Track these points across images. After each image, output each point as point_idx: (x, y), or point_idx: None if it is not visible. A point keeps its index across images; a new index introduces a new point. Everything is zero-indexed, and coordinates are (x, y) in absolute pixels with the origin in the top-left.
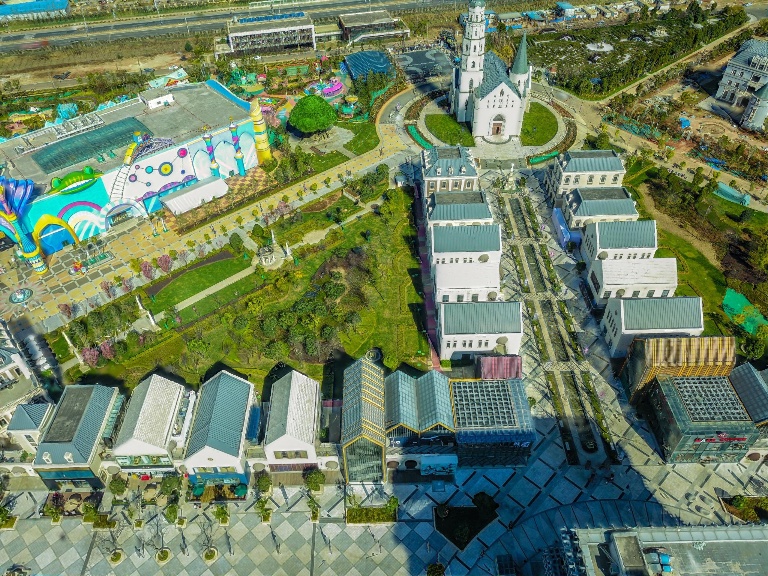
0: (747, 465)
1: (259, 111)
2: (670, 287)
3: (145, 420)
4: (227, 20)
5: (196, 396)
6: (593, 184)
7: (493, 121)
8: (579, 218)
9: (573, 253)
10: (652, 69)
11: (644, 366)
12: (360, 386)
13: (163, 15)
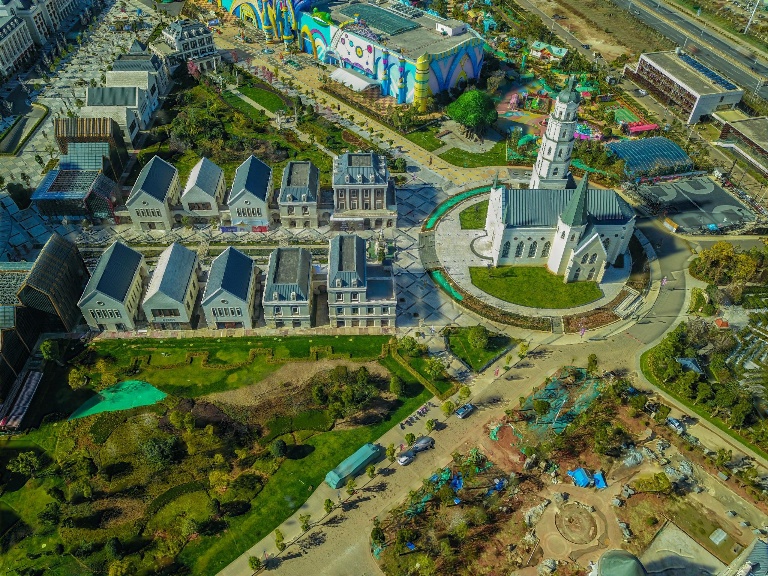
0: None
1: (421, 62)
2: None
3: (119, 74)
4: None
5: (165, 110)
6: None
7: None
8: None
9: None
10: None
11: None
12: None
13: (733, 37)
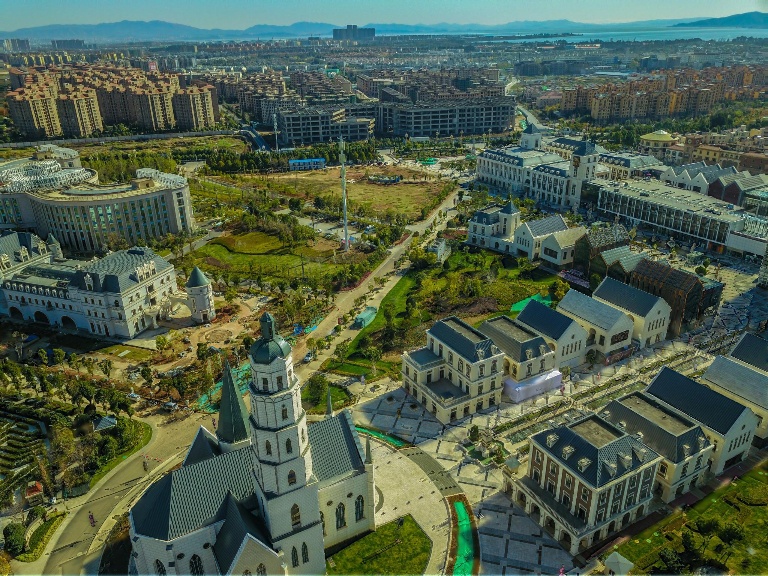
0: None
1: None
2: None
3: None
4: None
5: None
6: None
7: None
8: None
9: None
10: None
11: (701, 292)
12: None
13: None
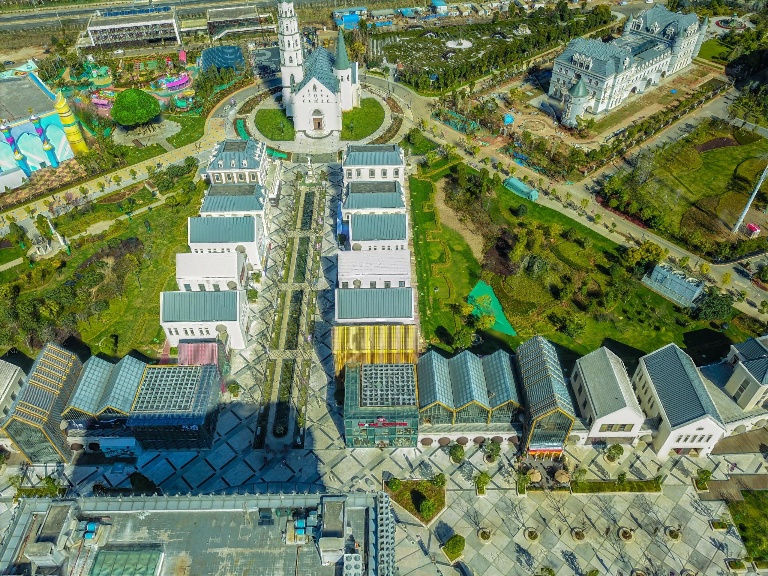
0: (423, 450)
1: (63, 103)
2: (404, 278)
3: None
4: (92, 14)
5: None
6: (376, 178)
7: (312, 116)
8: (347, 211)
9: (344, 245)
10: (500, 66)
11: None
12: (33, 370)
13: (46, 8)
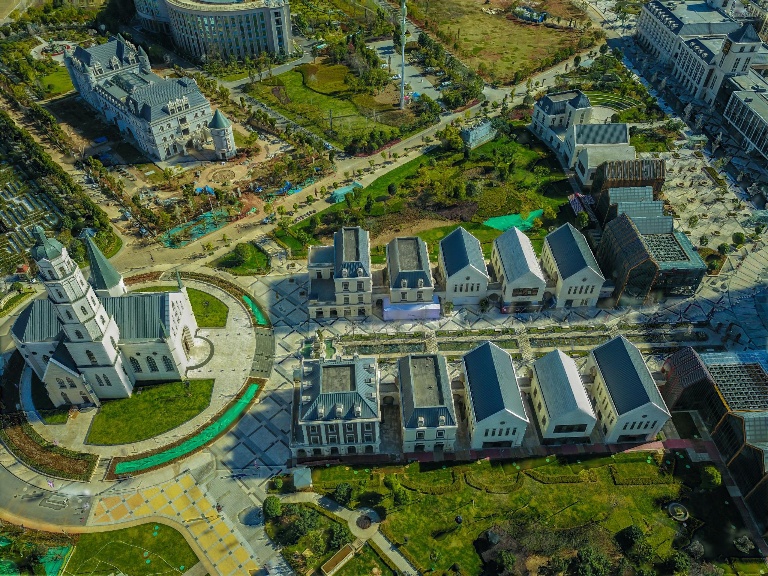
0: None
1: None
2: None
3: None
4: None
5: None
6: None
7: None
8: None
9: (451, 311)
10: None
11: (654, 271)
12: None
13: None
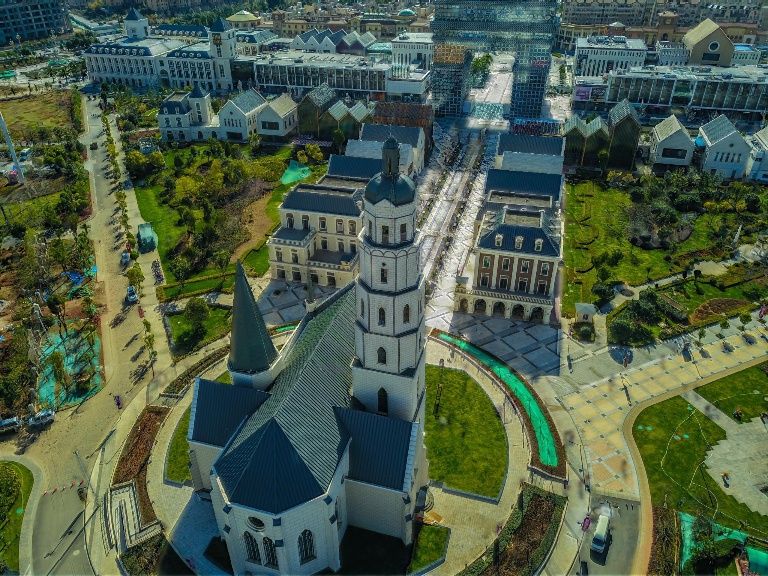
0: None
1: None
2: None
3: None
4: None
5: None
6: None
7: None
8: None
9: None
10: None
11: None
12: None
13: None
